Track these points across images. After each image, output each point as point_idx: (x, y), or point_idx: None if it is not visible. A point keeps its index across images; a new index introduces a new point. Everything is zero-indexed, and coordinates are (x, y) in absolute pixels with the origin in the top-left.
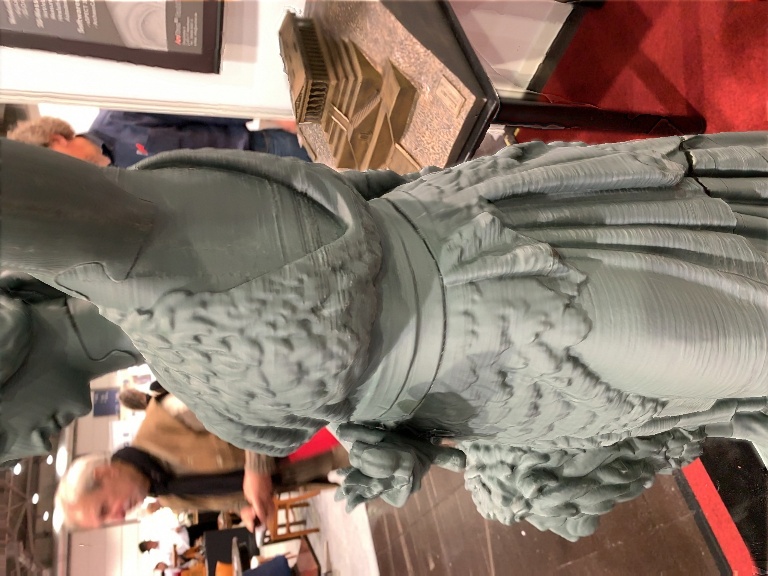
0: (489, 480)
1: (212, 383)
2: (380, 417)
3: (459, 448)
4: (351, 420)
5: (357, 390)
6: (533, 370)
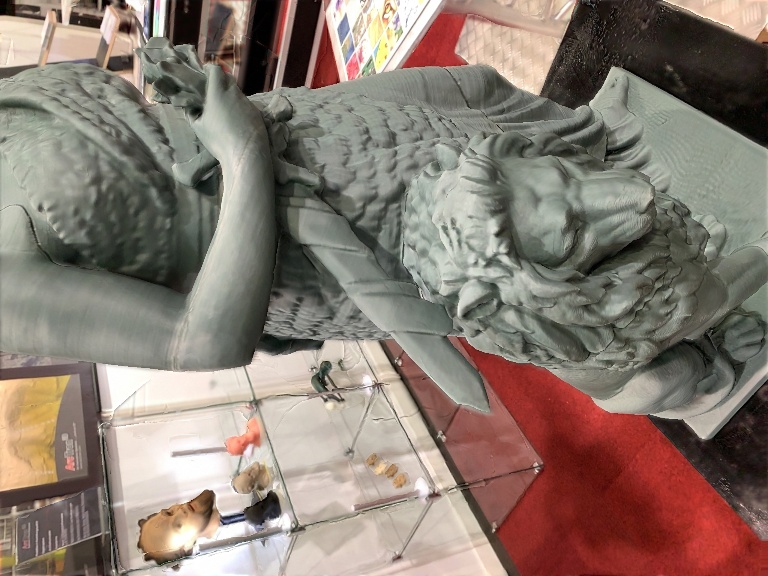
0: (432, 198)
1: (10, 80)
2: (199, 141)
3: (446, 295)
4: (172, 146)
5: (148, 109)
6: (273, 91)
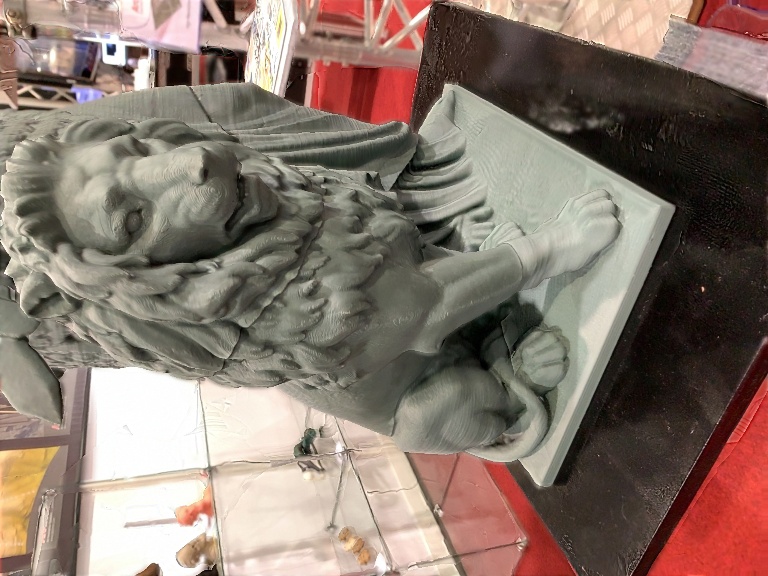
0: None
1: None
2: None
3: None
4: None
5: None
6: None
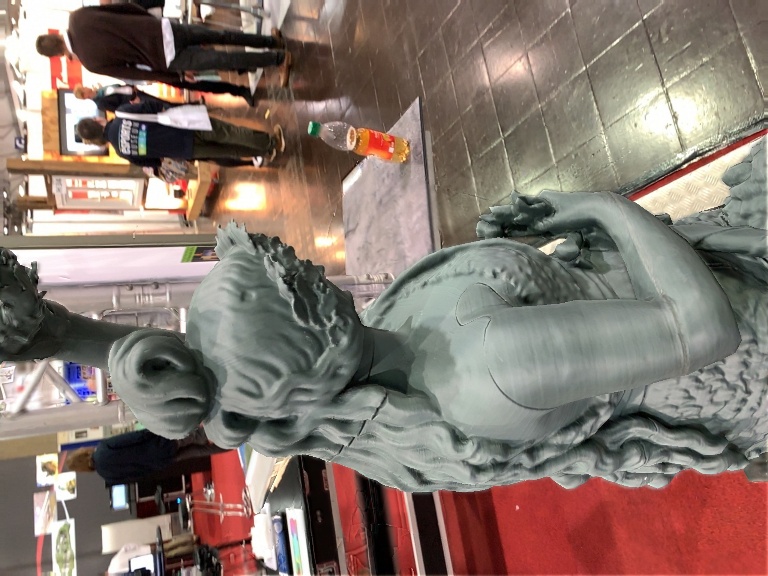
0: (760, 178)
1: None
2: None
3: None
4: None
5: None
6: None
